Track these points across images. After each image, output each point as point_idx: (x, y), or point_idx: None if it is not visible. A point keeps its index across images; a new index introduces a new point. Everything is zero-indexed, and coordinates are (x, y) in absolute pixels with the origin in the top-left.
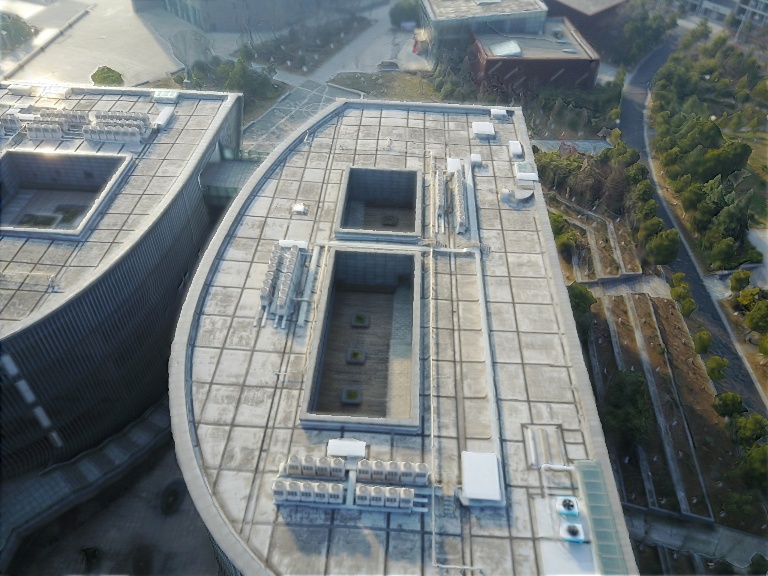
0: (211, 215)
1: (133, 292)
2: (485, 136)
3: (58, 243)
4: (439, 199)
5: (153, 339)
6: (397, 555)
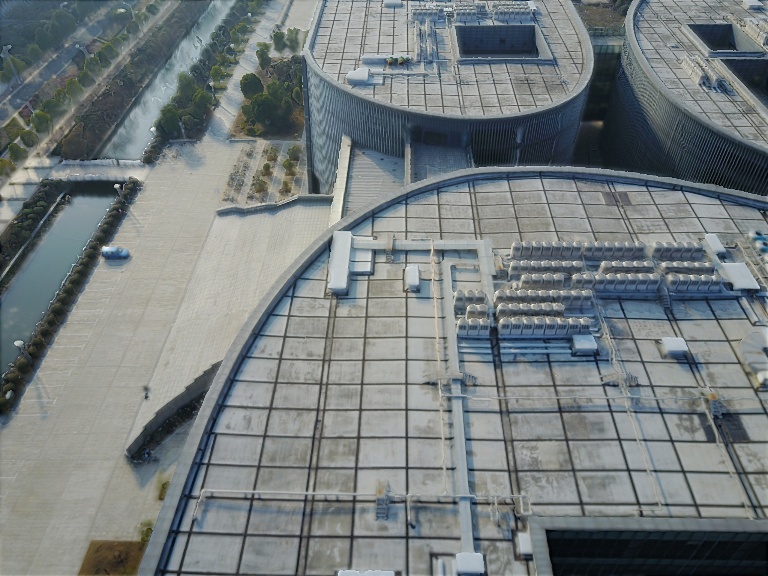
0: None
1: None
2: (756, 7)
3: (541, 65)
4: (764, 33)
5: None
6: None
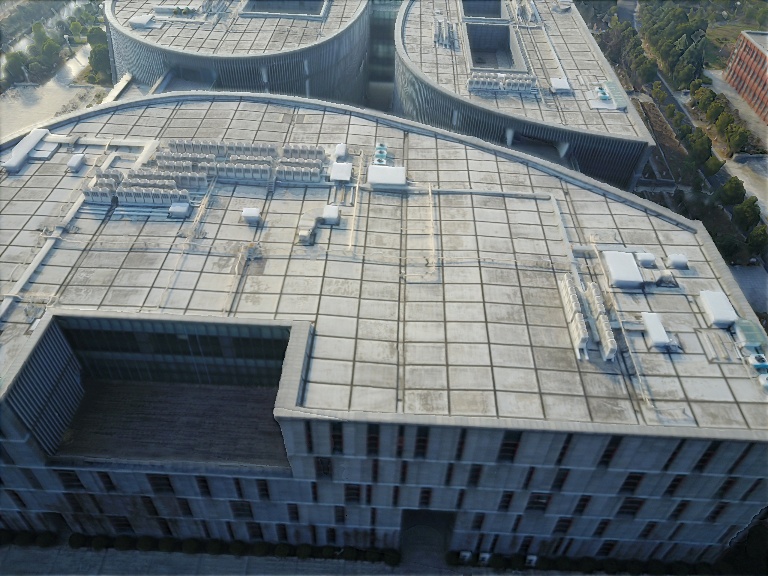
0: (371, 32)
1: (351, 51)
2: None
3: (311, 21)
4: (518, 5)
5: (352, 90)
6: (527, 102)
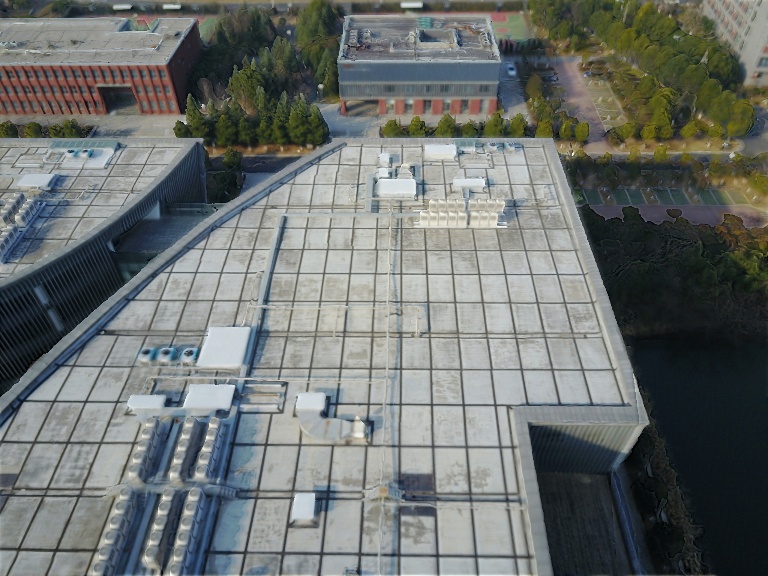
0: None
1: None
2: None
3: None
4: None
5: None
6: (66, 213)
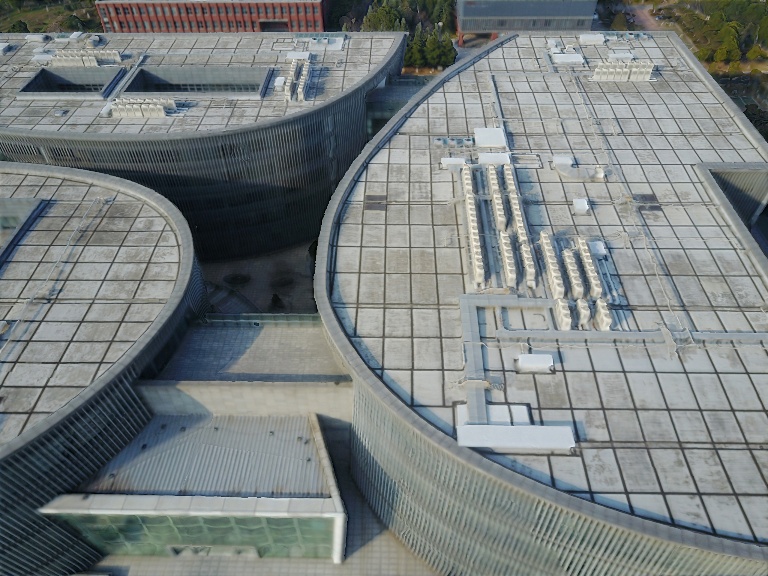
0: None
1: None
2: (7, 48)
3: (44, 213)
4: (90, 57)
5: None
6: None
